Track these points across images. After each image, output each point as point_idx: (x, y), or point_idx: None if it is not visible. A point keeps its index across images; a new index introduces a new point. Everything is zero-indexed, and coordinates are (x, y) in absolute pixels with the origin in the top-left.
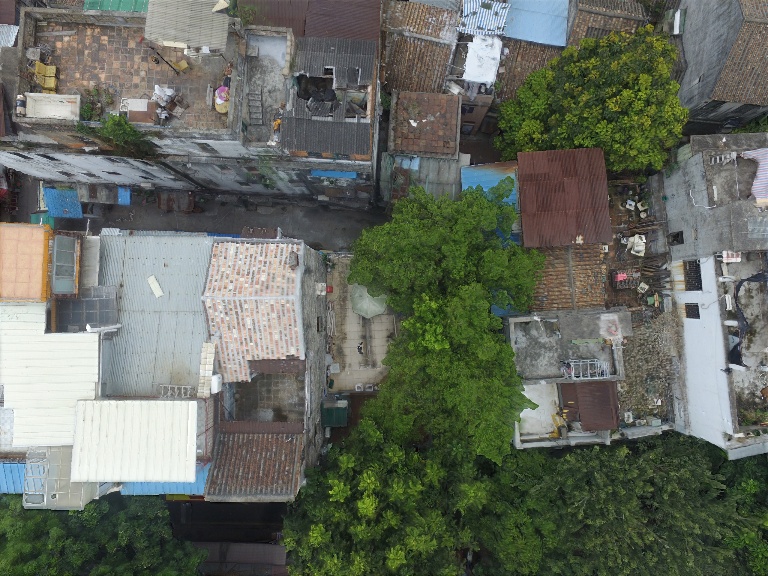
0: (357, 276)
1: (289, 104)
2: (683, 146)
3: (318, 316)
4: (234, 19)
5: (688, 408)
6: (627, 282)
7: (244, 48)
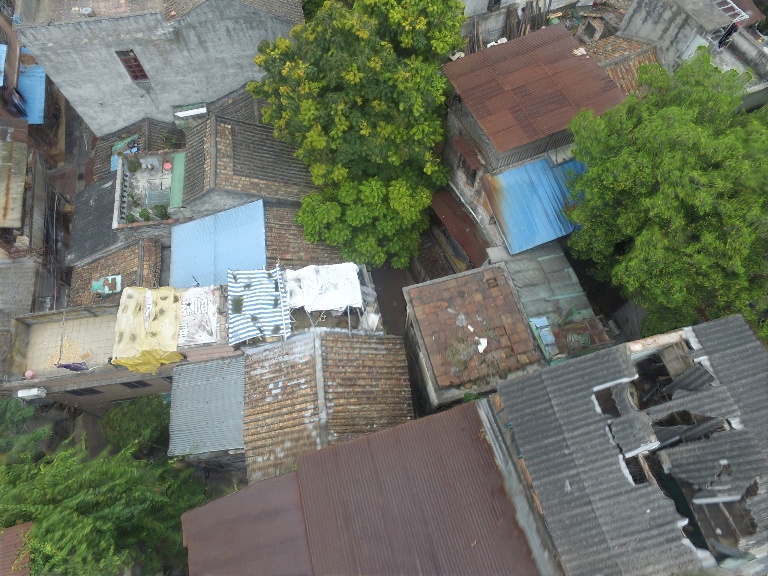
0: None
1: None
2: None
3: None
4: None
5: None
6: None
7: None
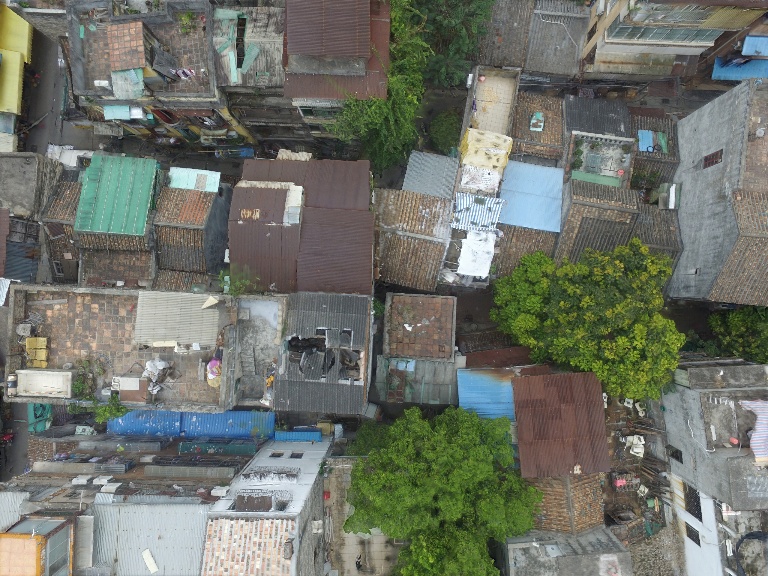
0: (353, 527)
1: (282, 368)
2: (680, 369)
3: (315, 546)
4: (224, 297)
5: None
6: (626, 486)
7: (235, 316)
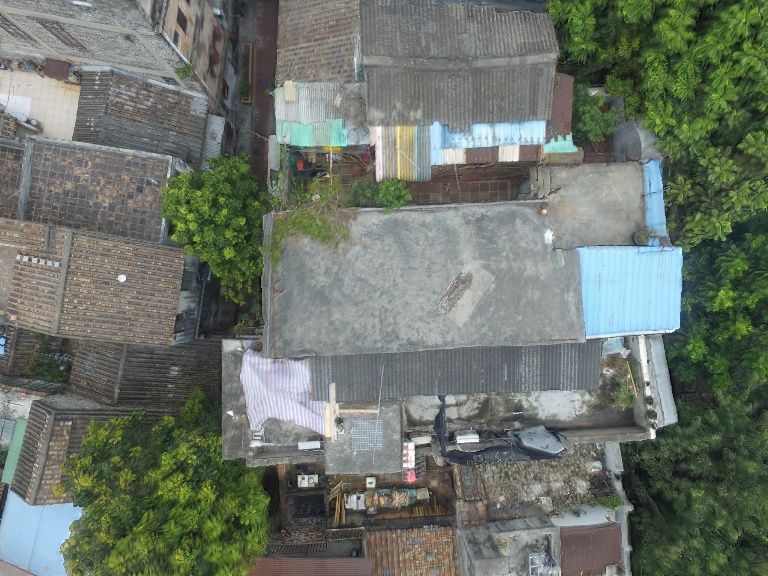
0: None
1: None
2: None
3: None
4: None
5: None
6: (418, 466)
7: None
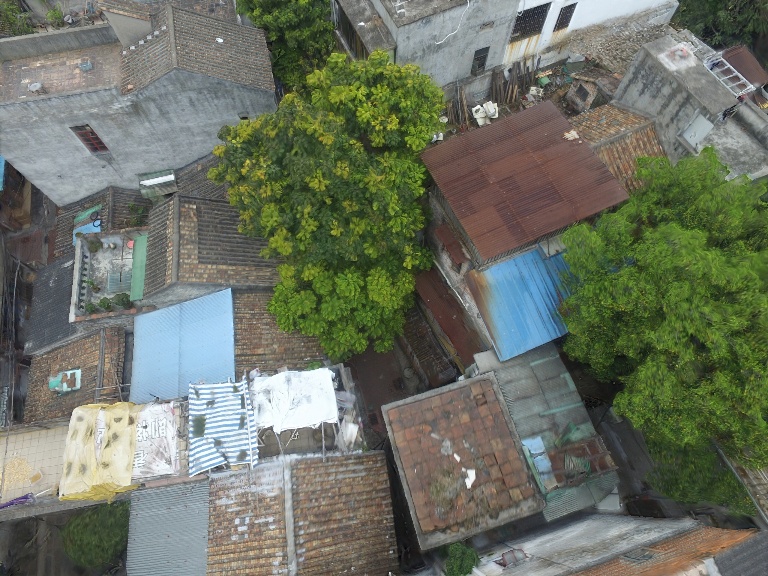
0: None
1: None
2: None
3: None
4: None
5: (653, 8)
6: None
7: None
